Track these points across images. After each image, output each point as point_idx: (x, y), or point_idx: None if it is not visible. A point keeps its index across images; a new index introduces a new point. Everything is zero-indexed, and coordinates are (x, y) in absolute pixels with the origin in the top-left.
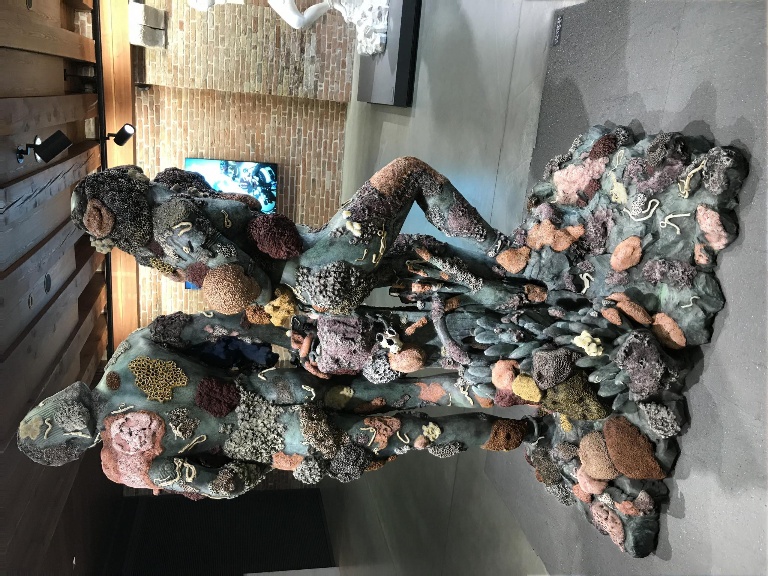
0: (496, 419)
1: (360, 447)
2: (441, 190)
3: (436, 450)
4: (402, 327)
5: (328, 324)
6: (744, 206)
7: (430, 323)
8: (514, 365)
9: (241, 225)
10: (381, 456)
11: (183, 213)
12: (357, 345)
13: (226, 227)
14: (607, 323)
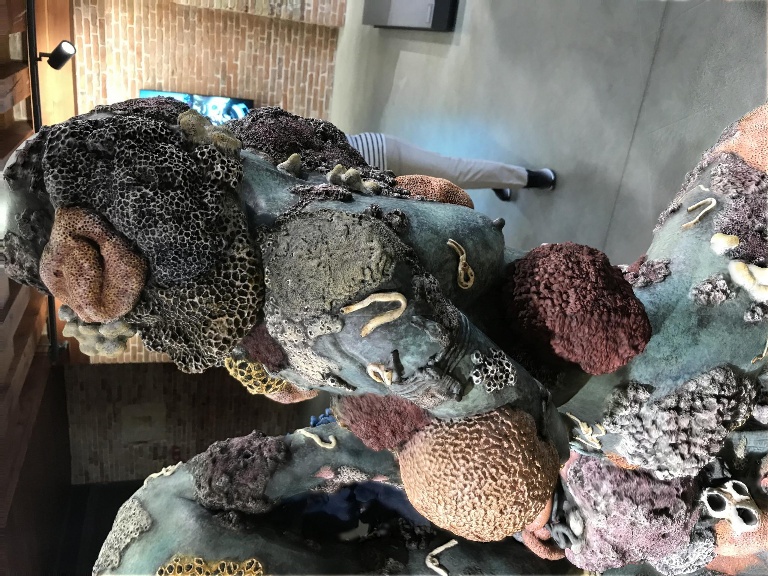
0: None
1: None
2: None
3: None
4: (738, 465)
5: (612, 477)
6: None
7: None
8: None
9: (490, 277)
10: None
11: (377, 263)
12: (677, 525)
13: (460, 287)
14: None
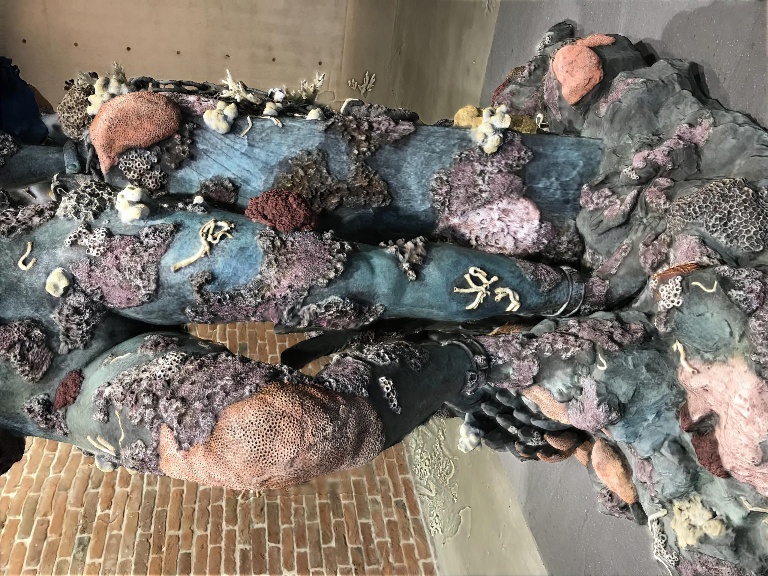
0: None
1: None
2: None
3: None
4: None
5: None
6: None
7: None
8: None
9: None
10: None
11: None
12: None
13: None
14: None
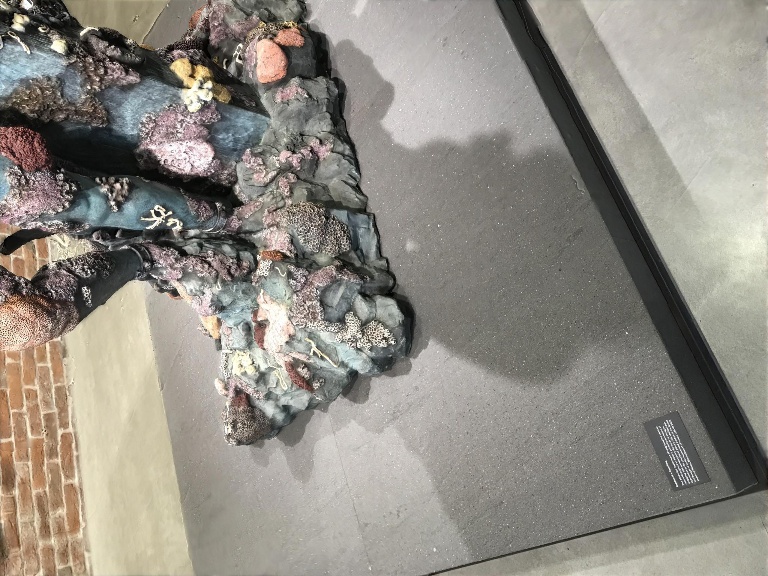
0: None
1: None
2: None
3: None
4: None
5: None
6: None
7: None
8: None
9: None
10: None
11: None
12: None
13: None
14: None
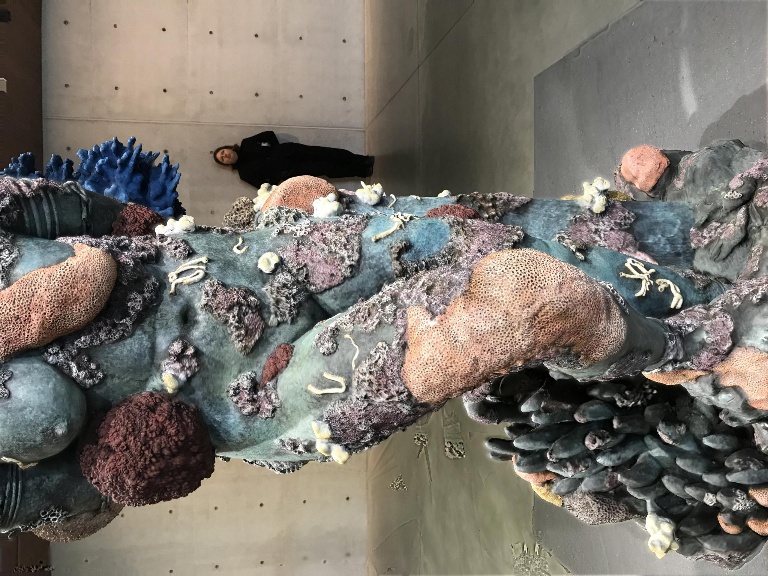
0: None
1: None
2: (584, 368)
3: None
4: None
5: None
6: None
7: None
8: (549, 479)
9: None
10: None
11: None
12: None
13: None
14: None
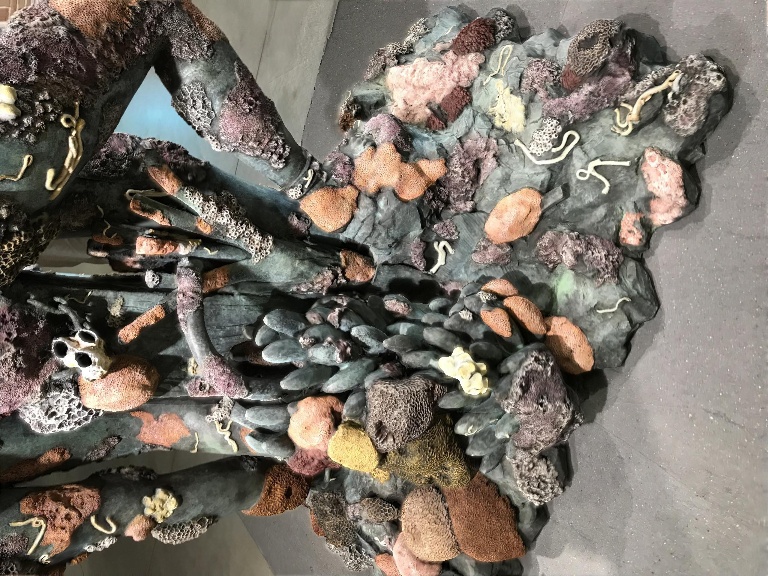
0: (270, 465)
1: (7, 562)
2: (211, 52)
3: (166, 535)
4: (111, 323)
5: None
6: (715, 160)
7: (169, 314)
8: (333, 406)
9: None
10: (55, 563)
11: None
12: (3, 367)
13: None
14: (484, 331)
